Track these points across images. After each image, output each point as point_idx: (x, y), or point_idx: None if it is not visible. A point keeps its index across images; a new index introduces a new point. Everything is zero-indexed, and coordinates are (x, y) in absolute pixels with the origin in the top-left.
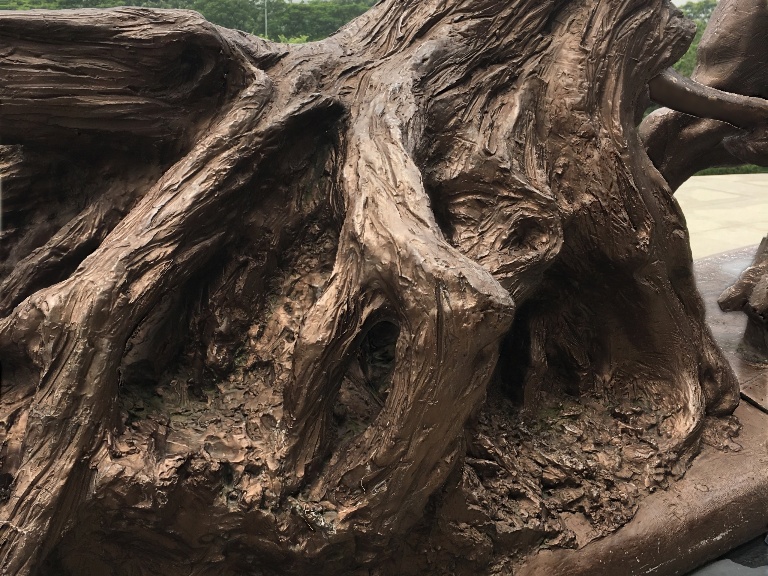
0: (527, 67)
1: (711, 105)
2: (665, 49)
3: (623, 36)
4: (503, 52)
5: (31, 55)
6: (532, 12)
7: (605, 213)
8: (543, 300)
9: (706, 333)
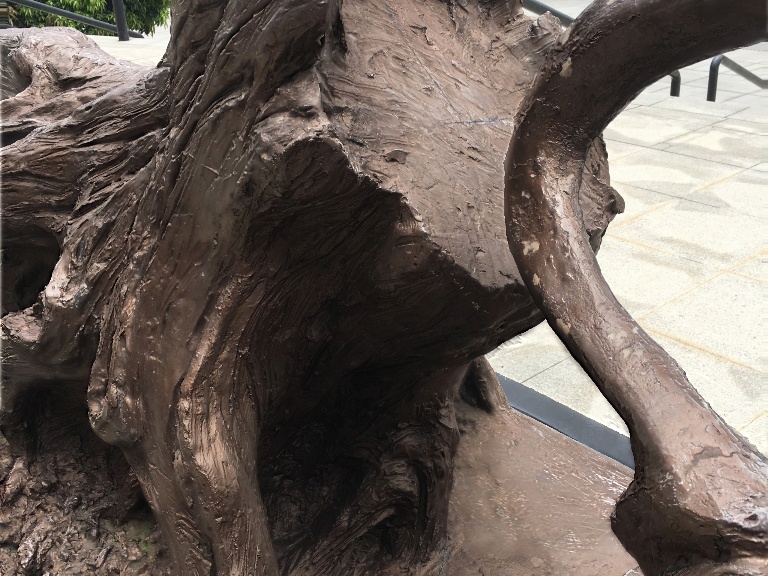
0: None
1: None
2: (244, 168)
3: (200, 128)
4: None
5: None
6: None
7: None
8: None
9: None
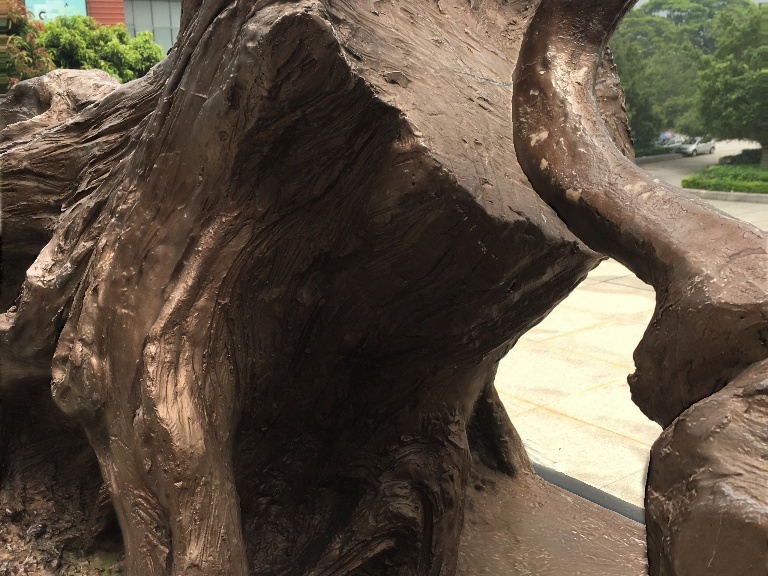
0: None
1: None
2: None
3: None
4: None
5: (25, 106)
6: None
7: None
8: None
9: None
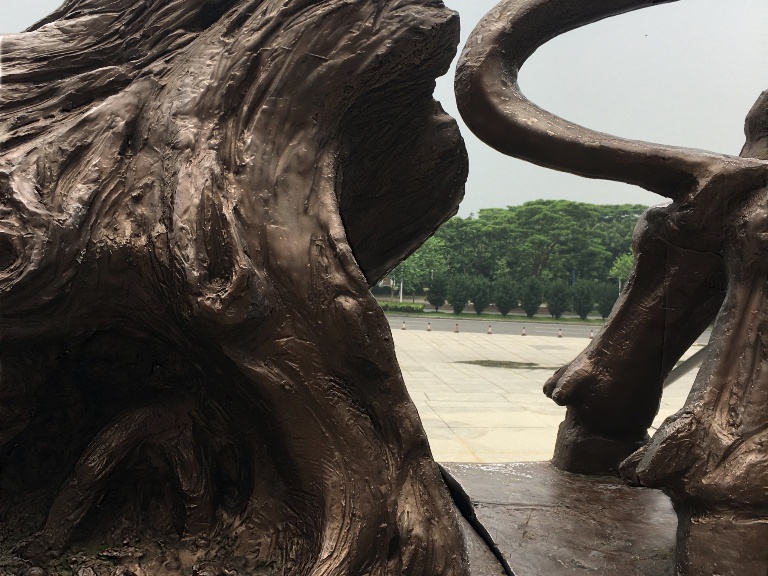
0: (146, 67)
1: (593, 156)
2: (380, 44)
3: (296, 25)
4: (125, 52)
5: None
6: (172, 3)
7: (169, 249)
8: (165, 389)
9: (419, 478)
